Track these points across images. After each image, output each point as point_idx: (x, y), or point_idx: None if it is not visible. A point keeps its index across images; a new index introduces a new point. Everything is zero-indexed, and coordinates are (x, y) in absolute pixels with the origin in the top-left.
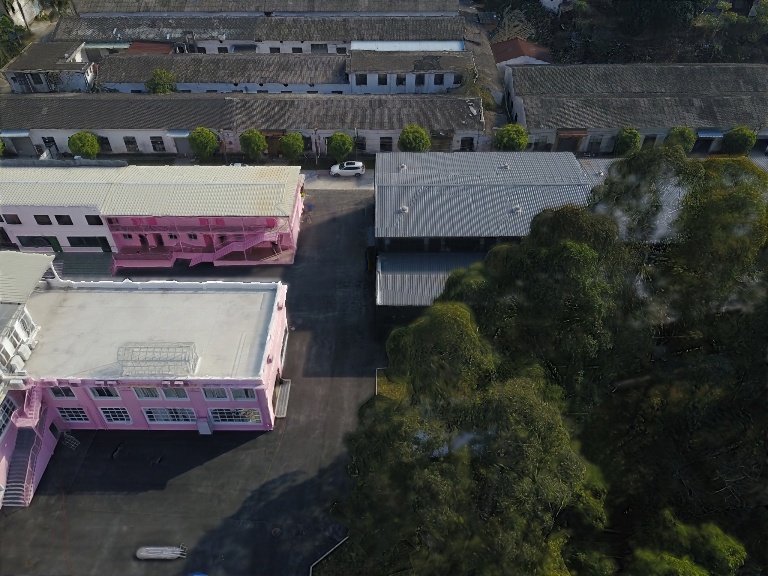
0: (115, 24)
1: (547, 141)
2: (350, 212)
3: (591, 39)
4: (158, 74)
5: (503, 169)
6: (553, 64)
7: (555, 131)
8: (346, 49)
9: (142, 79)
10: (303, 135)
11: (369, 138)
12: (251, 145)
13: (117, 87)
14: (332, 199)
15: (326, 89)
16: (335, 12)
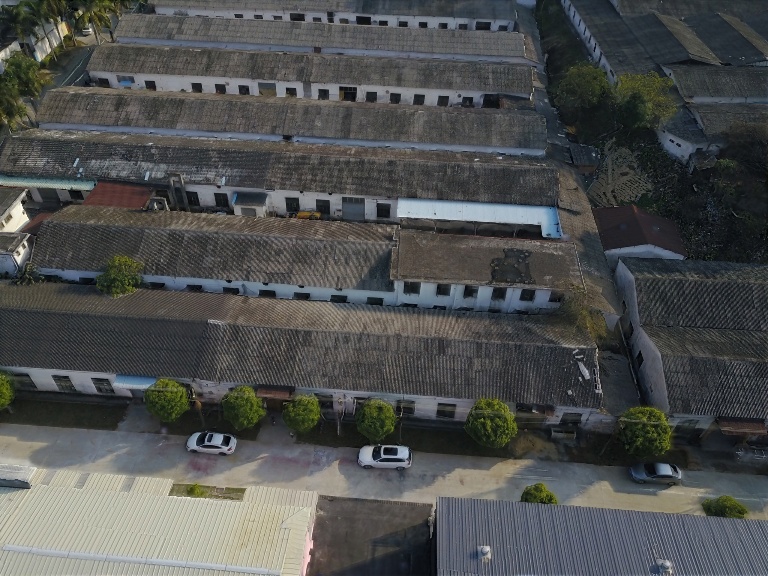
0: (78, 151)
1: (697, 425)
2: (386, 564)
3: (738, 214)
4: (116, 265)
5: (661, 574)
6: (690, 263)
7: (713, 417)
8: (390, 205)
9: (95, 265)
10: (320, 396)
11: (421, 402)
12: (238, 419)
13: (59, 273)
14: (359, 526)
15: (359, 294)
16: (378, 141)
